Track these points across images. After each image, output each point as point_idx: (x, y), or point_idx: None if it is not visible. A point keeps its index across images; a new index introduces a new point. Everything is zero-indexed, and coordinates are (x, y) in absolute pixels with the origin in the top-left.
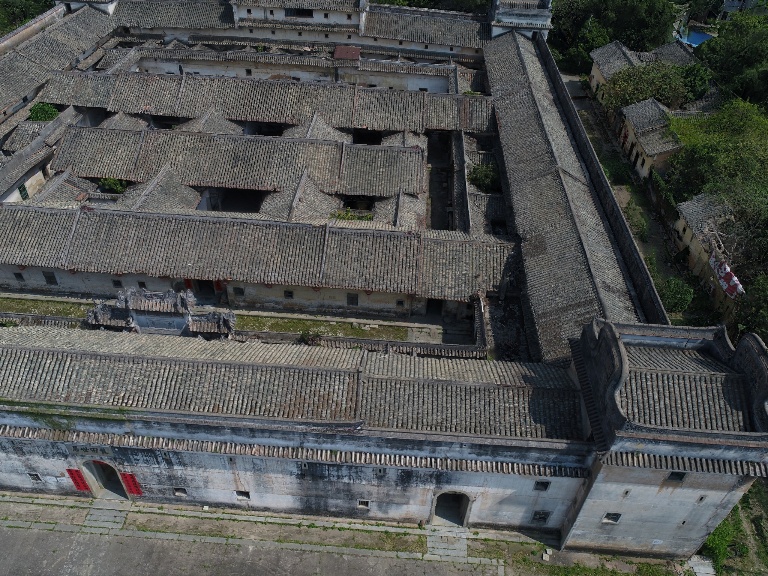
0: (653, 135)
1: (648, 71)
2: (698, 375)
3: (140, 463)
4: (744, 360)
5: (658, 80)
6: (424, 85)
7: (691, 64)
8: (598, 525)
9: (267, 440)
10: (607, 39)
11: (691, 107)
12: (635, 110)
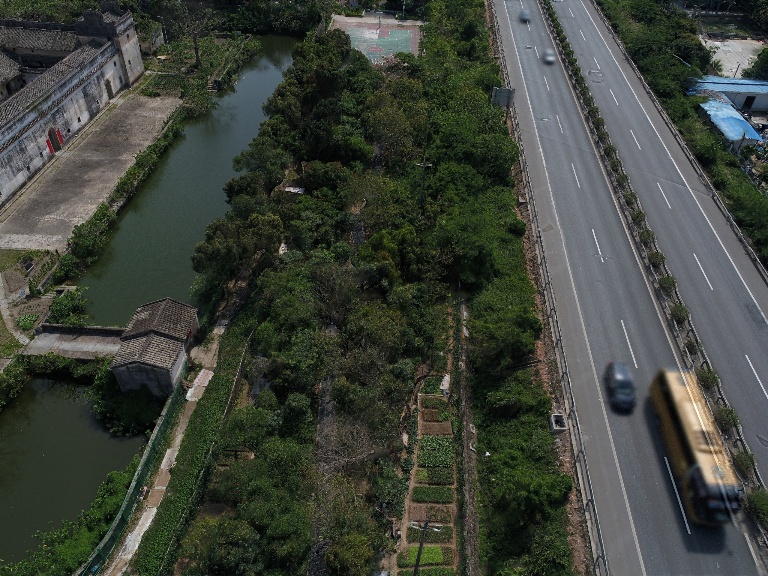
0: None
1: None
2: None
3: None
4: (106, 7)
5: None
6: None
7: None
8: None
9: None
10: None
11: None
12: None
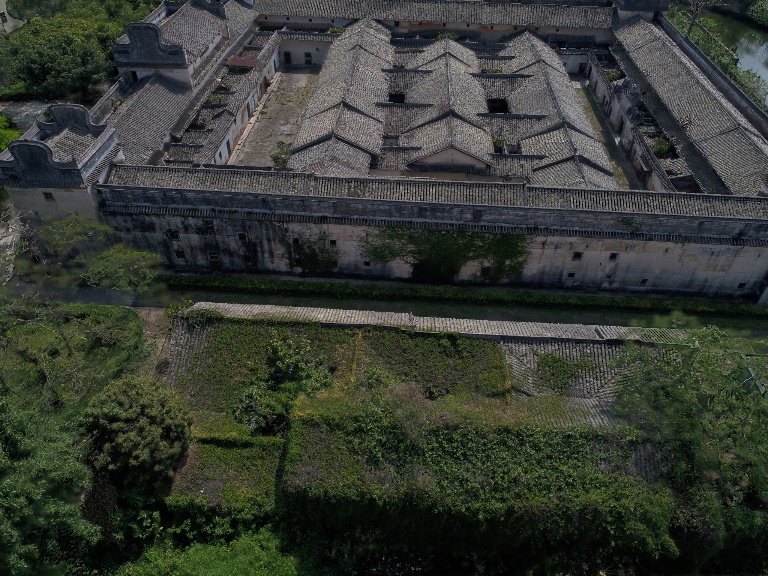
0: None
1: None
2: None
3: None
4: None
5: None
6: None
7: None
8: None
9: None
10: None
11: None
12: None
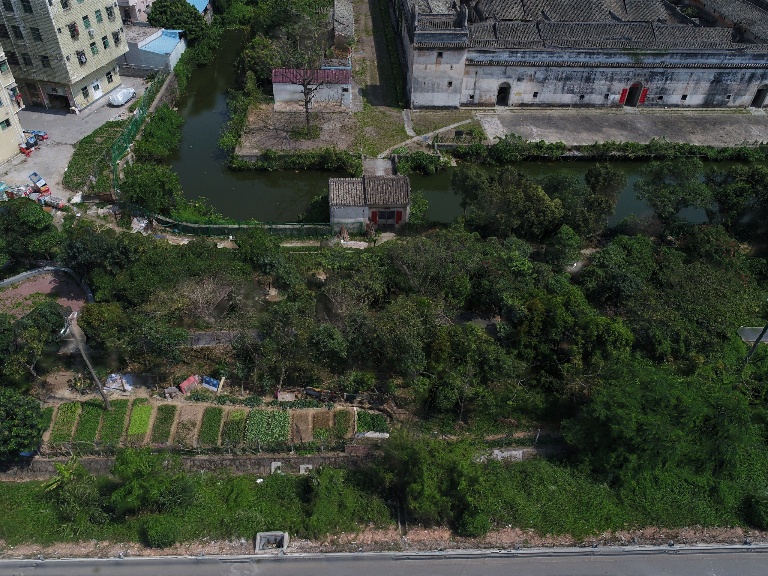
0: None
1: None
2: None
3: (655, 81)
4: None
5: None
6: None
7: None
8: None
9: (711, 60)
10: None
11: None
12: None
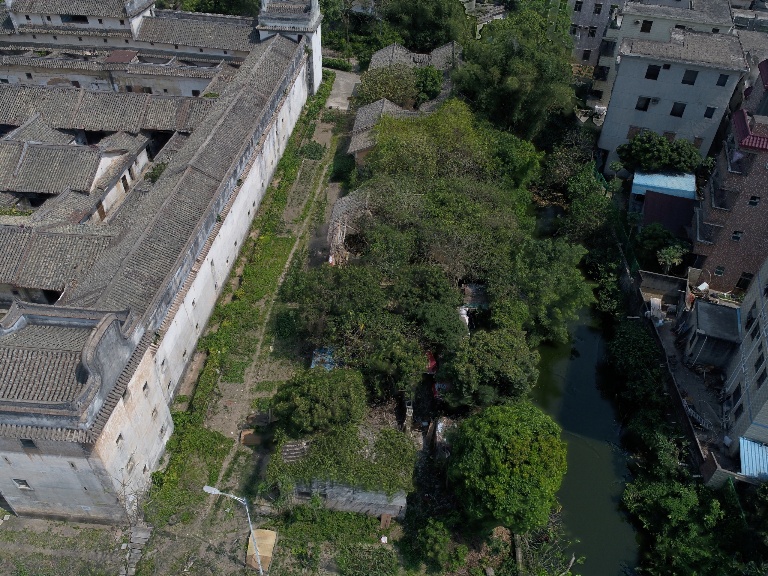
0: (364, 134)
1: (384, 72)
2: (60, 351)
3: None
4: None
5: (393, 81)
6: (195, 87)
7: (448, 65)
8: (20, 491)
9: None
10: (397, 41)
11: (424, 107)
12: (366, 110)
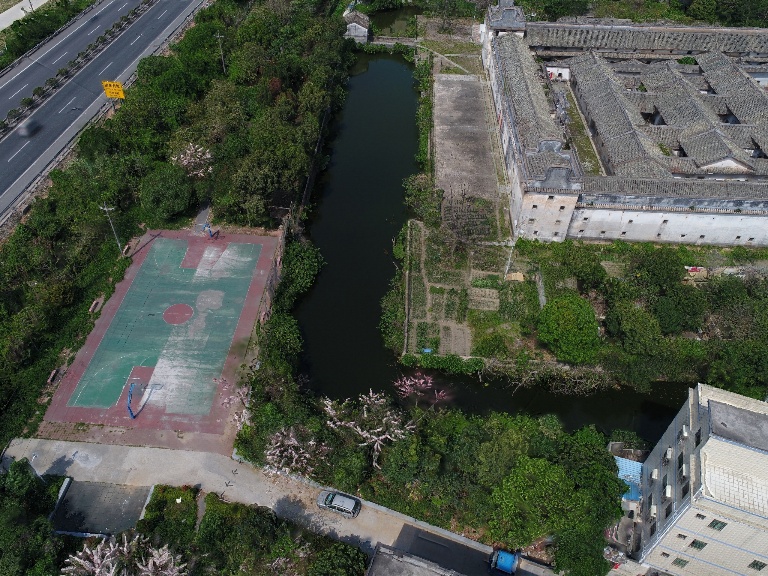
0: None
1: None
2: None
3: None
4: None
5: None
6: None
7: None
8: None
9: None
10: None
11: None
12: None
